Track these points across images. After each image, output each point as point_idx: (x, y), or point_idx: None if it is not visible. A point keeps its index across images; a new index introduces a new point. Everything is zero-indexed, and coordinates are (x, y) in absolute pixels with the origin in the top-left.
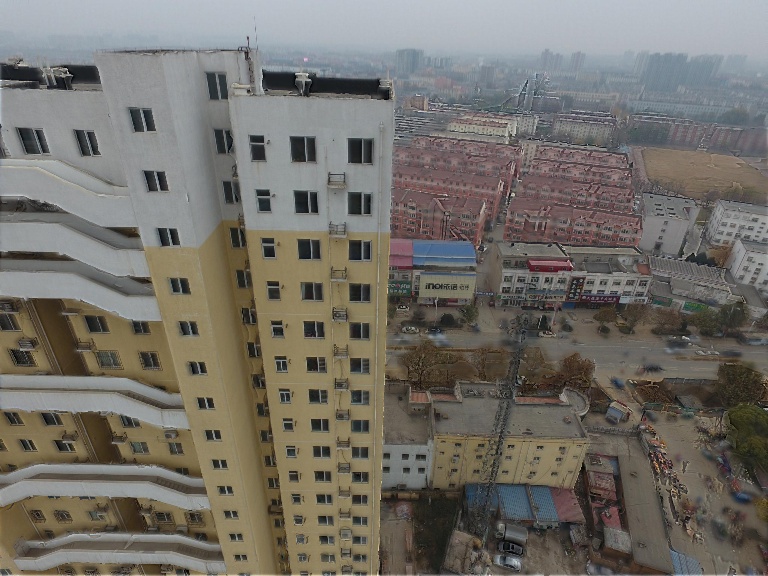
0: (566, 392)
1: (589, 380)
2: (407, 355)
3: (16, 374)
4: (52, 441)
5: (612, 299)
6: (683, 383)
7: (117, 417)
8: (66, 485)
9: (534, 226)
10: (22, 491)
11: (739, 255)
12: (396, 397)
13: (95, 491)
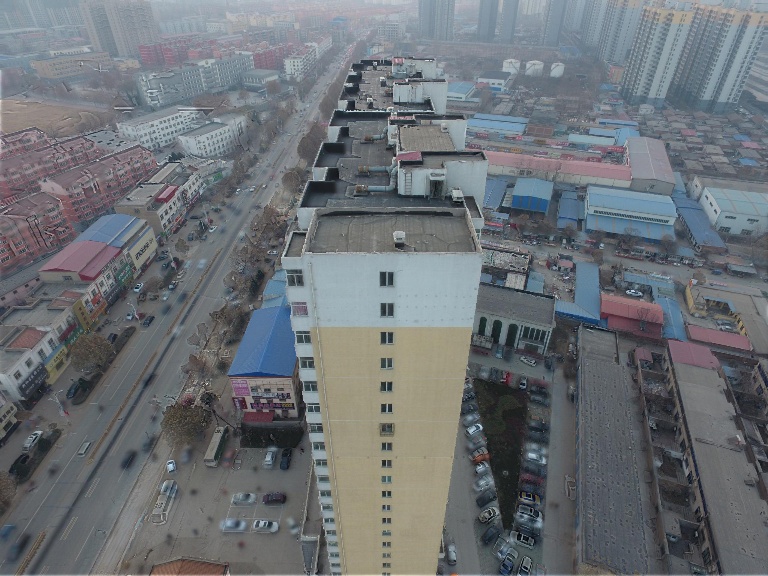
0: None
1: (274, 215)
2: (233, 266)
3: None
4: None
5: (198, 195)
6: (273, 201)
7: None
8: None
9: (92, 189)
10: None
11: (190, 143)
12: None
13: None
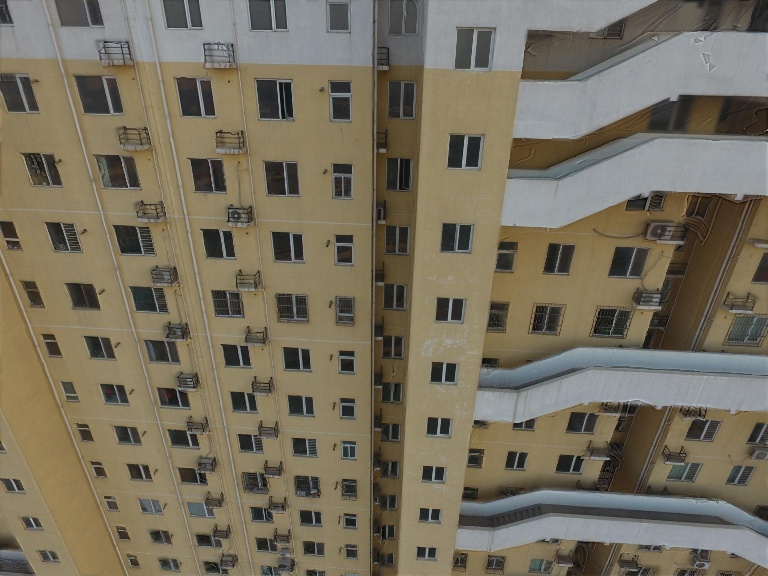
0: None
1: None
2: None
3: (618, 347)
4: (558, 456)
5: None
6: None
7: (687, 423)
8: (616, 526)
9: None
10: (539, 531)
11: None
12: None
13: (654, 537)
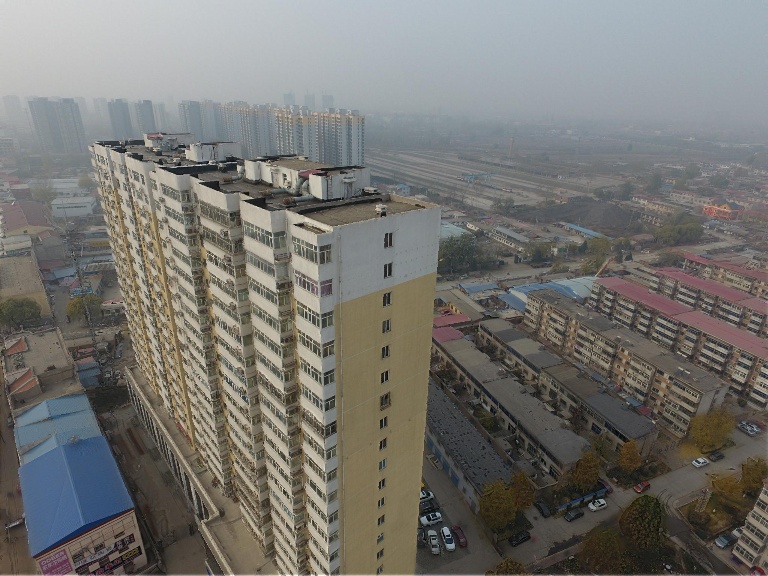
0: (10, 338)
1: None
2: None
3: None
4: None
5: None
6: None
7: None
8: None
9: None
10: None
11: None
12: (21, 405)
13: None
